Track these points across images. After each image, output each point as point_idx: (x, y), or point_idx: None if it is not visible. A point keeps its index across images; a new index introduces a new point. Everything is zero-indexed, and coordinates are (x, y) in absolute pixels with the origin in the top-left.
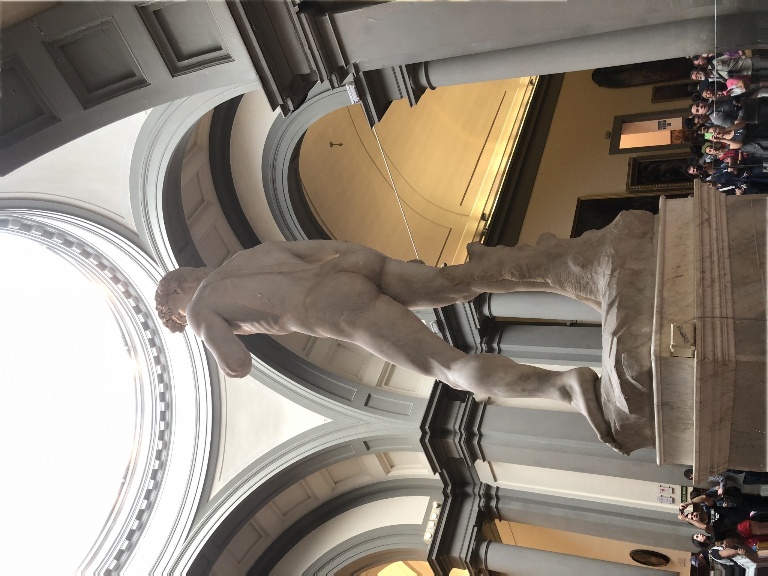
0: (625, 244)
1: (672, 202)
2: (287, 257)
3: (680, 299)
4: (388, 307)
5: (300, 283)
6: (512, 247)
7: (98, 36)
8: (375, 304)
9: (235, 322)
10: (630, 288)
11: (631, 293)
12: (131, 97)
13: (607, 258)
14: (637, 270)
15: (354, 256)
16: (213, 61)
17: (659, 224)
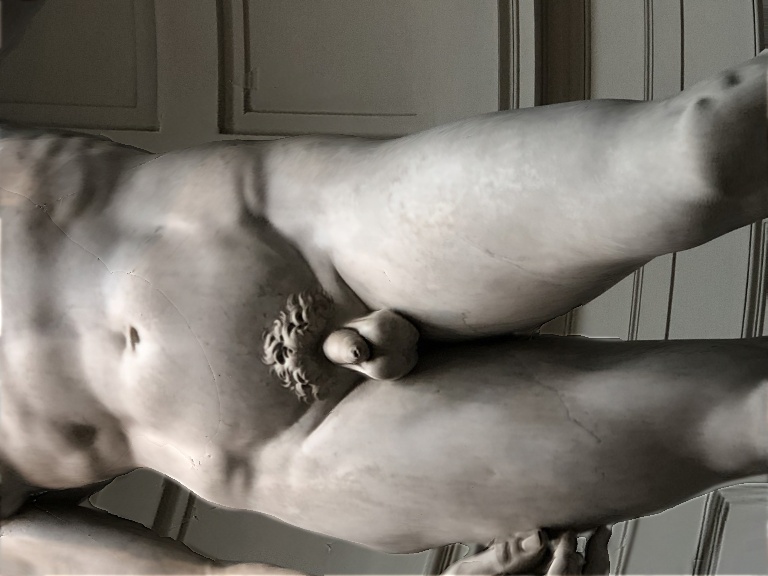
0: None
1: None
2: None
3: None
4: None
5: None
6: None
7: None
8: None
9: None
10: None
11: None
12: None
13: None
14: None
15: None
16: None
17: None
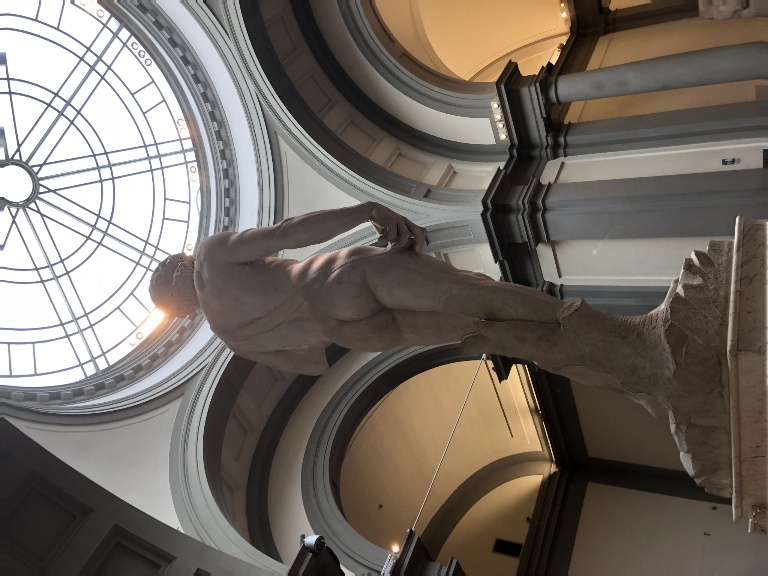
0: (687, 402)
1: (746, 359)
2: (262, 301)
3: (761, 479)
4: (419, 336)
5: (309, 328)
6: (533, 341)
7: None
8: (404, 338)
9: None
10: (702, 446)
11: (704, 450)
12: None
13: (667, 407)
14: (707, 429)
15: (340, 313)
16: None
17: (730, 391)
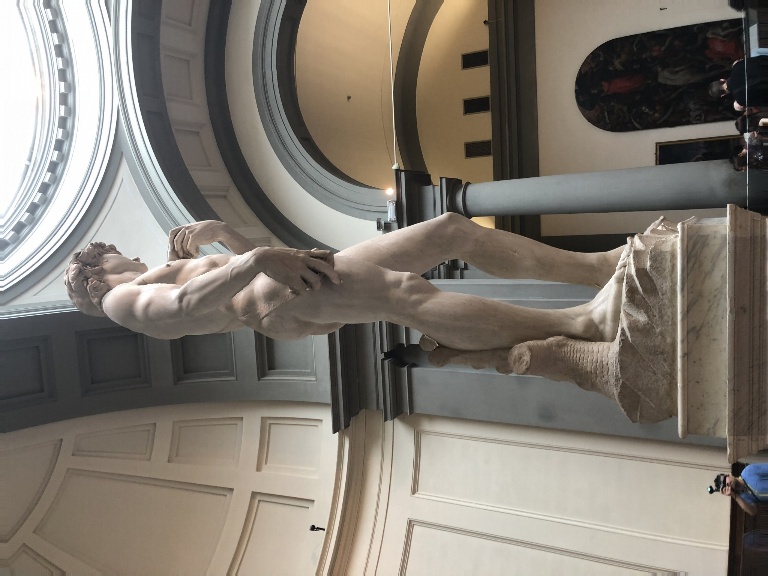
0: None
1: None
2: None
3: None
4: None
5: None
6: None
7: None
8: None
9: None
10: None
11: None
12: None
13: None
14: None
15: None
16: None
17: None
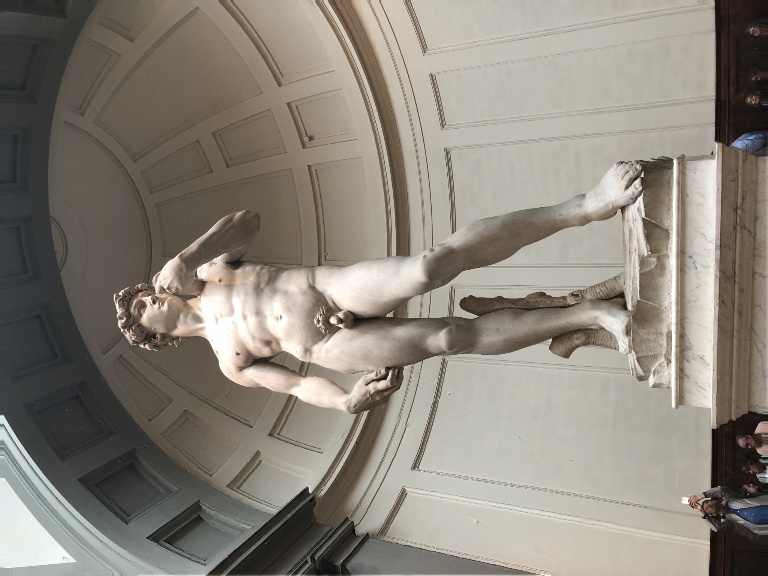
0: None
1: None
2: None
3: None
4: None
5: None
6: None
7: (150, 490)
8: None
9: (241, 265)
10: None
11: None
12: (105, 514)
13: None
14: None
15: None
16: (188, 558)
17: None
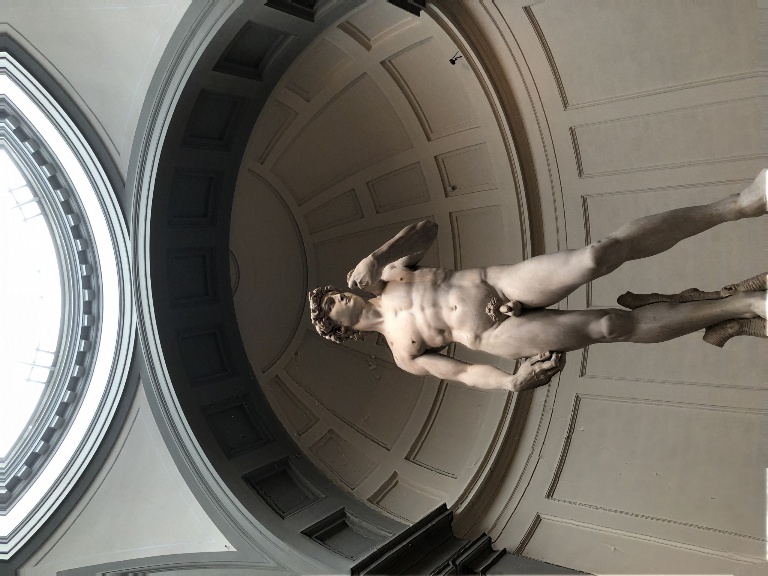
0: None
1: None
2: None
3: None
4: None
5: None
6: None
7: None
8: None
9: None
10: None
11: None
12: (264, 508)
13: None
14: None
15: None
16: (337, 553)
17: None
